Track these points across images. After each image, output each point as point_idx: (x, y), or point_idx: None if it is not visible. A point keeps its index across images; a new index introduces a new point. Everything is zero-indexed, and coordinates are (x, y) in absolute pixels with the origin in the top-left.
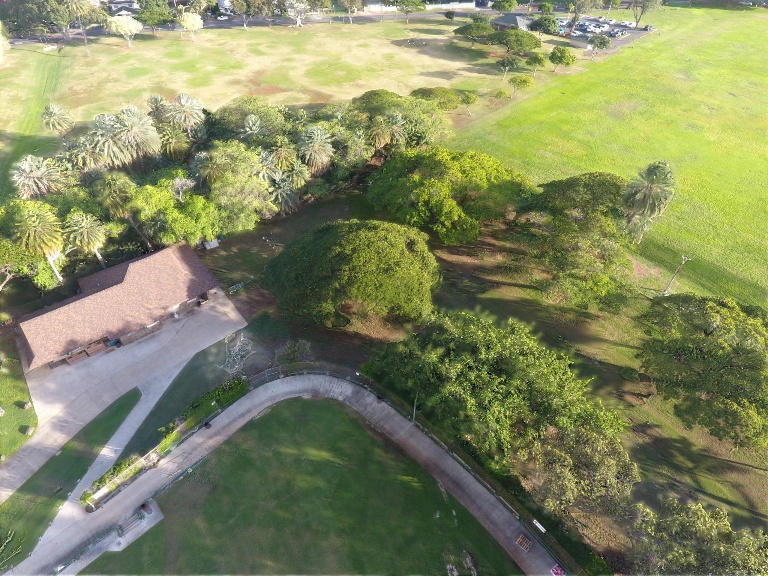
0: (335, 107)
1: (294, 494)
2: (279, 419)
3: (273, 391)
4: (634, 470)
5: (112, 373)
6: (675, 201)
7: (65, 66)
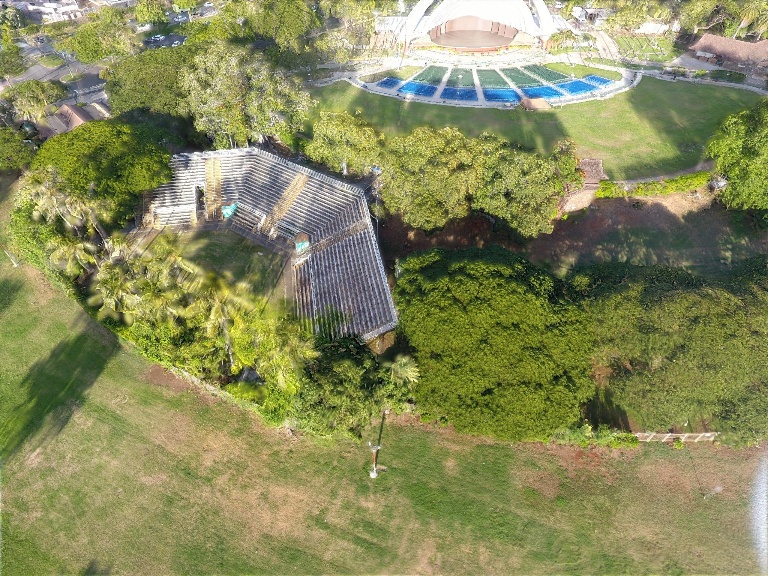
0: None
1: (715, 98)
2: (740, 91)
3: (751, 88)
4: None
5: (707, 68)
6: None
7: None
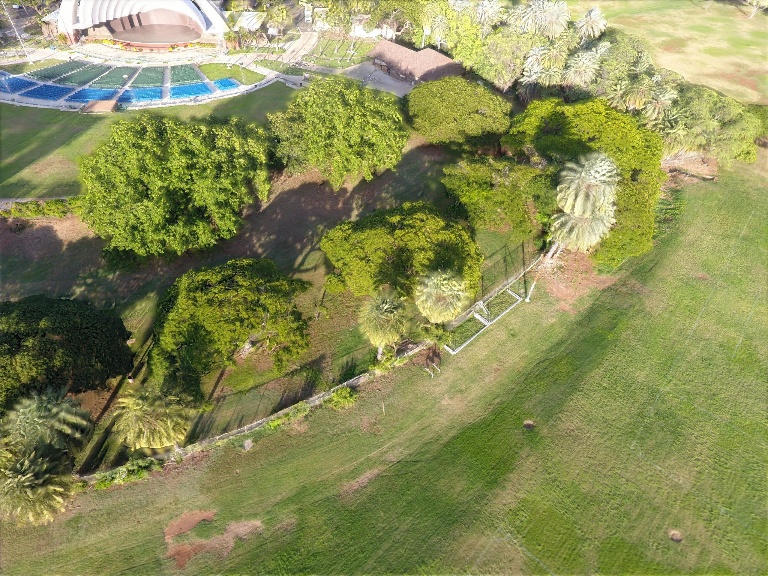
0: (667, 72)
1: None
2: None
3: None
4: (284, 141)
5: None
6: (761, 372)
7: (677, 8)
